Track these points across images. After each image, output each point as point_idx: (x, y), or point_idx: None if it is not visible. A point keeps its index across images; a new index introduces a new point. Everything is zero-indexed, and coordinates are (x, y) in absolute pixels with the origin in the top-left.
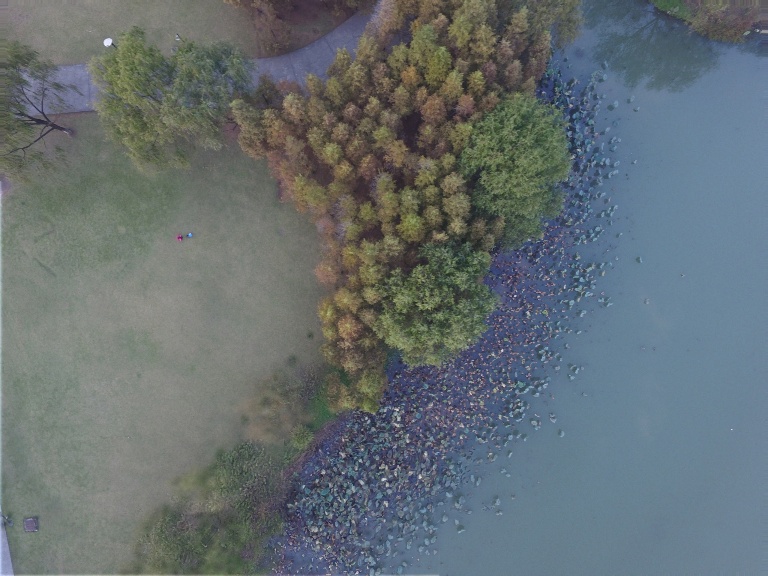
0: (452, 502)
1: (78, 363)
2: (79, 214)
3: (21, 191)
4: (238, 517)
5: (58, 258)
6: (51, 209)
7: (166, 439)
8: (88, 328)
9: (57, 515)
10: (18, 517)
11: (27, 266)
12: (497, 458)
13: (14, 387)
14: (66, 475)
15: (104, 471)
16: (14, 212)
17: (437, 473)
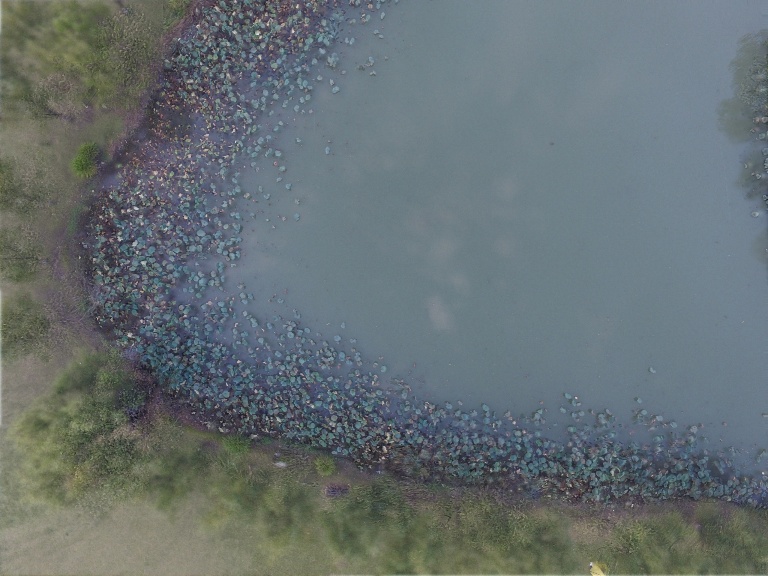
0: (325, 58)
1: None
2: None
3: None
4: (118, 78)
5: None
6: None
7: (48, 2)
8: None
9: None
10: None
11: None
12: (370, 19)
13: None
14: None
15: None
16: None
17: (309, 26)
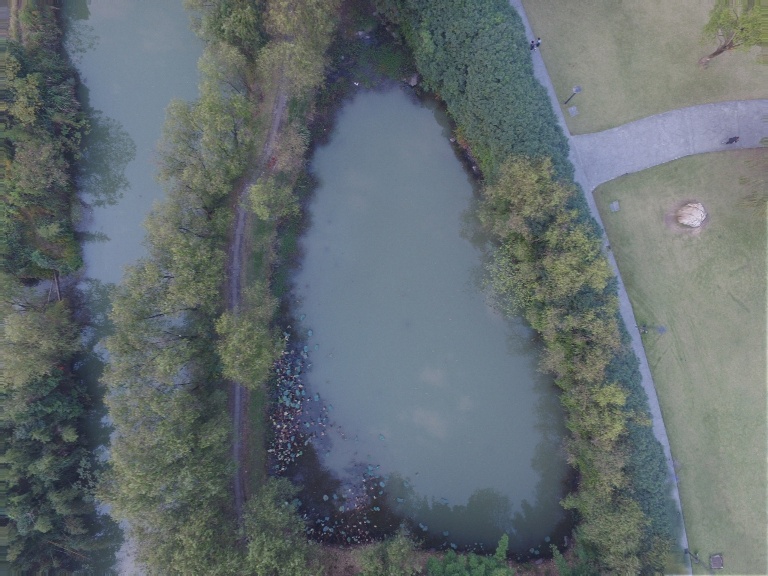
0: None
1: None
2: None
3: (719, 224)
4: None
5: (752, 293)
6: (747, 243)
7: None
8: None
9: (741, 552)
10: (704, 554)
11: (721, 300)
12: None
13: (704, 423)
14: (753, 512)
15: None
16: (711, 245)
17: None
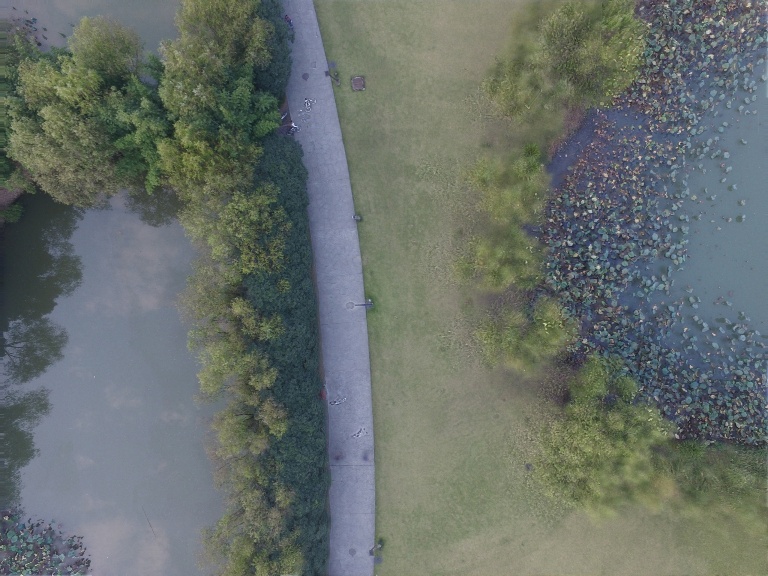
0: None
1: None
2: None
3: None
4: (560, 78)
5: None
6: None
7: None
8: None
9: (383, 75)
10: (345, 76)
11: None
12: None
13: None
14: (392, 33)
15: (429, 30)
16: None
17: (760, 26)
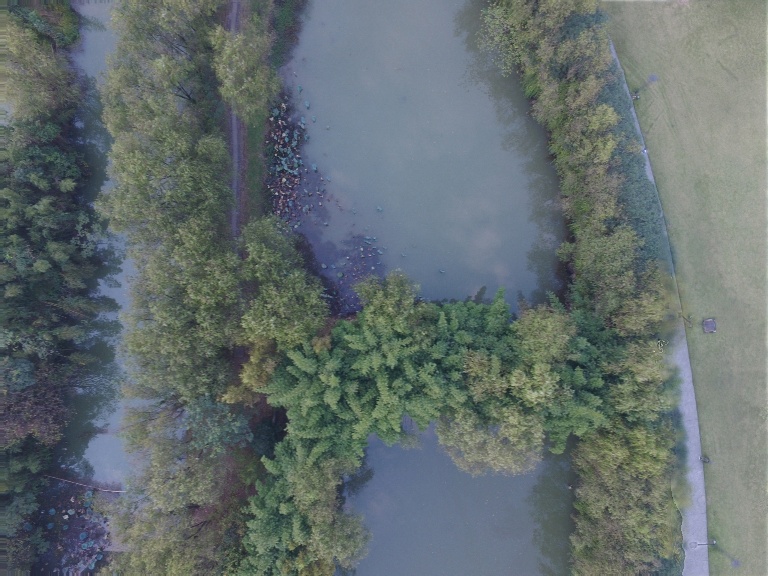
0: None
1: (758, 166)
2: (761, 19)
3: None
4: None
5: (740, 62)
6: (735, 13)
7: None
8: (767, 132)
9: (733, 317)
10: (697, 318)
11: (711, 68)
12: None
13: (695, 188)
14: (744, 277)
15: None
16: (700, 14)
17: None
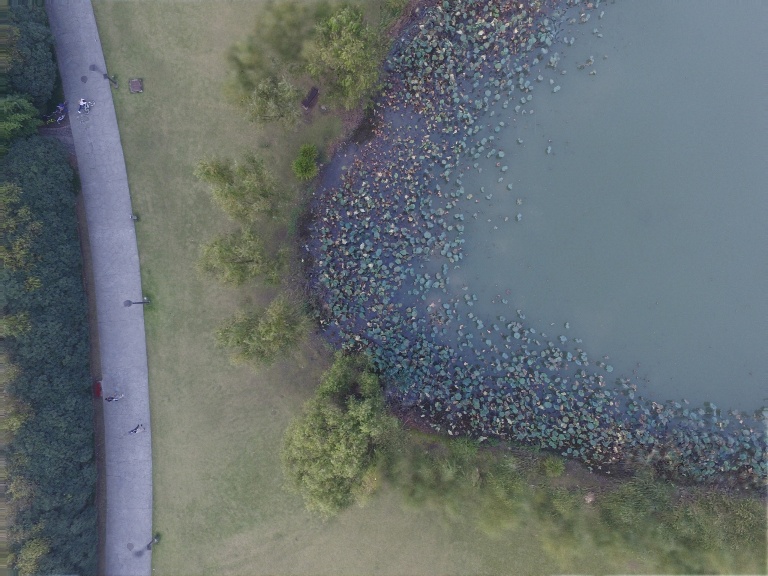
0: (547, 58)
1: None
2: None
3: None
4: (337, 79)
5: None
6: None
7: (266, 3)
8: None
9: (161, 77)
10: (123, 79)
11: None
12: (589, 19)
13: None
14: (170, 37)
15: (207, 33)
16: None
17: (533, 26)
